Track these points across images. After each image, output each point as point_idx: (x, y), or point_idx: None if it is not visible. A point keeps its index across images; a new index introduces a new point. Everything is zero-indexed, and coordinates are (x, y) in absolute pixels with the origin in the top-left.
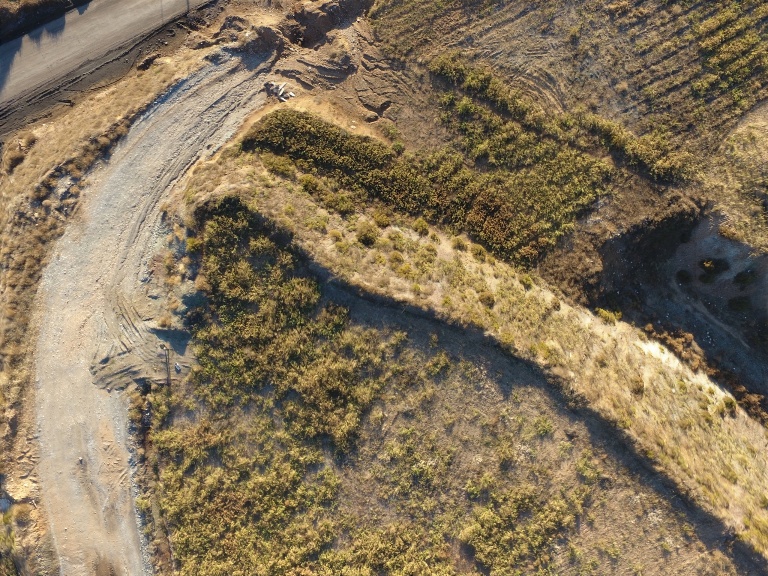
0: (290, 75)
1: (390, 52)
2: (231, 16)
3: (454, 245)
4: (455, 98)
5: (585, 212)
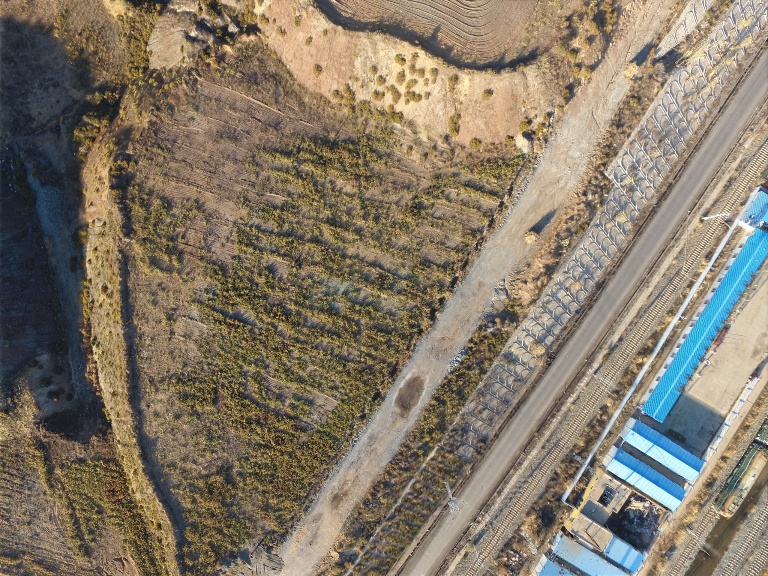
0: None
1: None
2: None
3: None
4: (90, 541)
5: (81, 461)
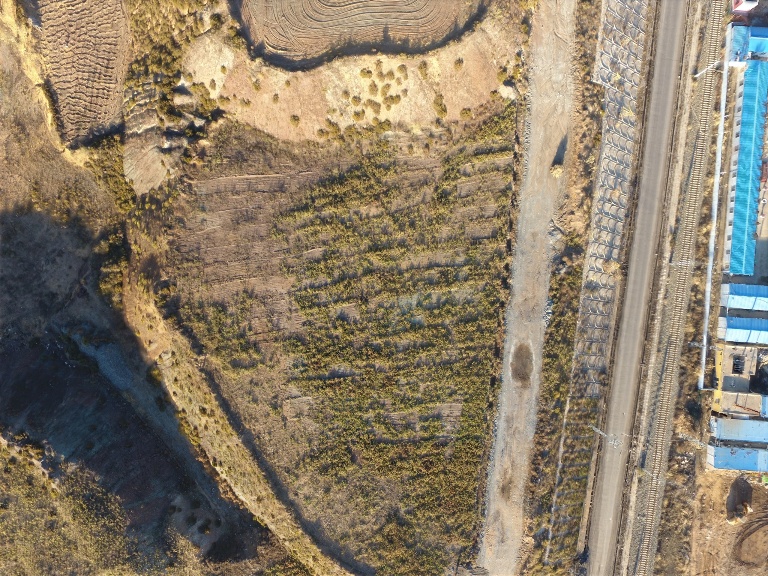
0: None
1: None
2: None
3: None
4: None
5: (258, 574)
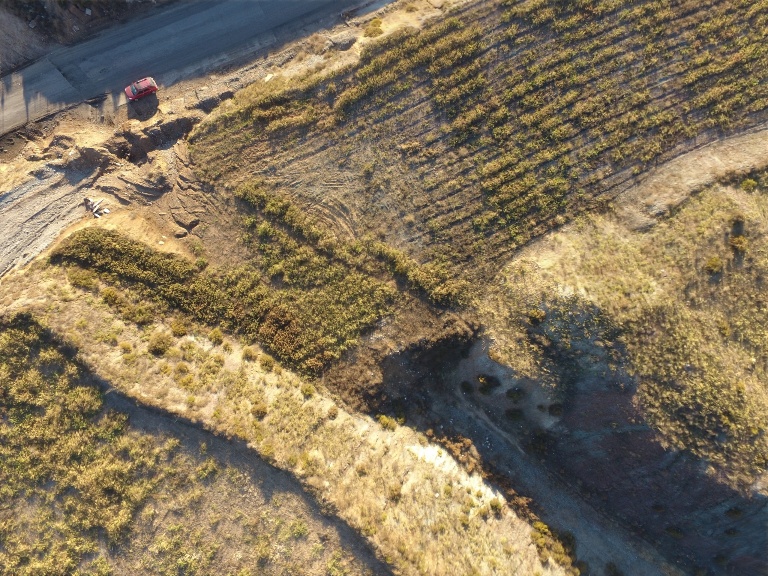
0: (109, 191)
1: (201, 176)
2: (58, 135)
3: (243, 356)
4: (256, 221)
5: (369, 329)
